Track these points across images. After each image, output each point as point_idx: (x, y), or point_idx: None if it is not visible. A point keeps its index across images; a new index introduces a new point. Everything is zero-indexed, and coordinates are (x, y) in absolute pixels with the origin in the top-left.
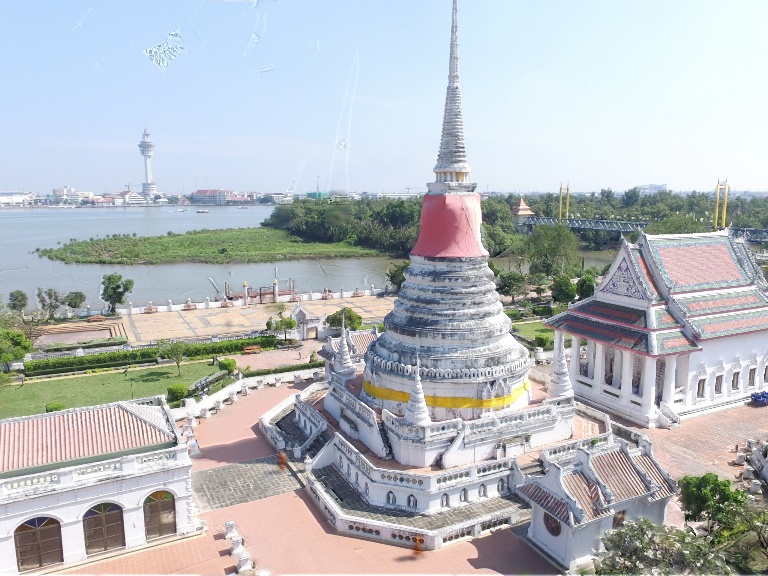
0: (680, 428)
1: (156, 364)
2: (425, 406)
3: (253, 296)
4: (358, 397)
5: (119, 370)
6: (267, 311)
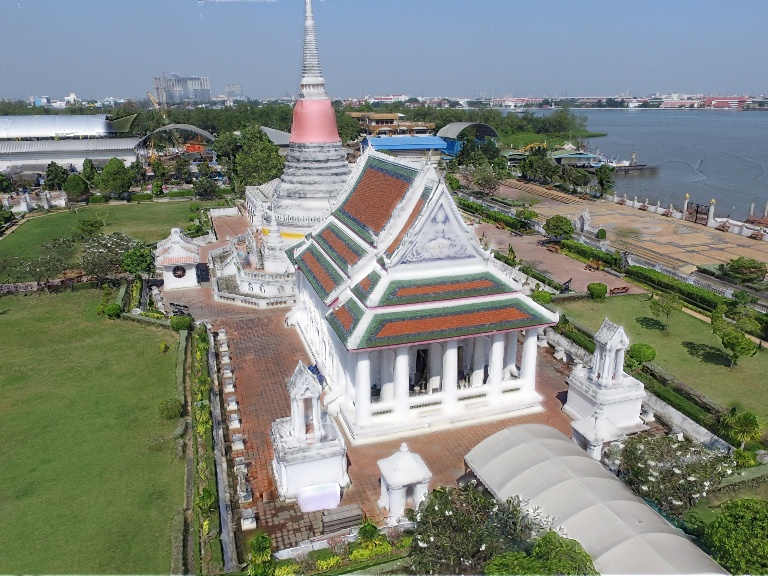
0: (282, 326)
1: (472, 215)
2: (258, 215)
3: (764, 223)
4: None
5: (462, 212)
6: (657, 225)
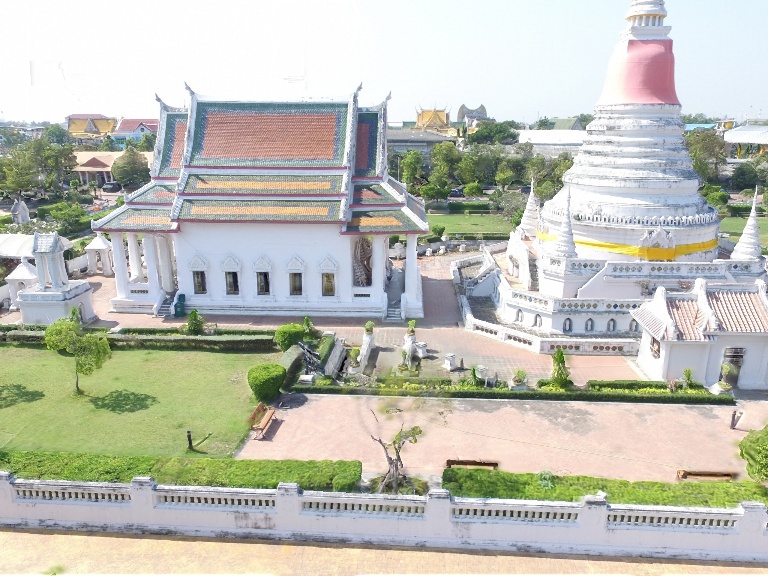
0: None
1: None
2: None
3: None
4: (723, 253)
5: None
6: None
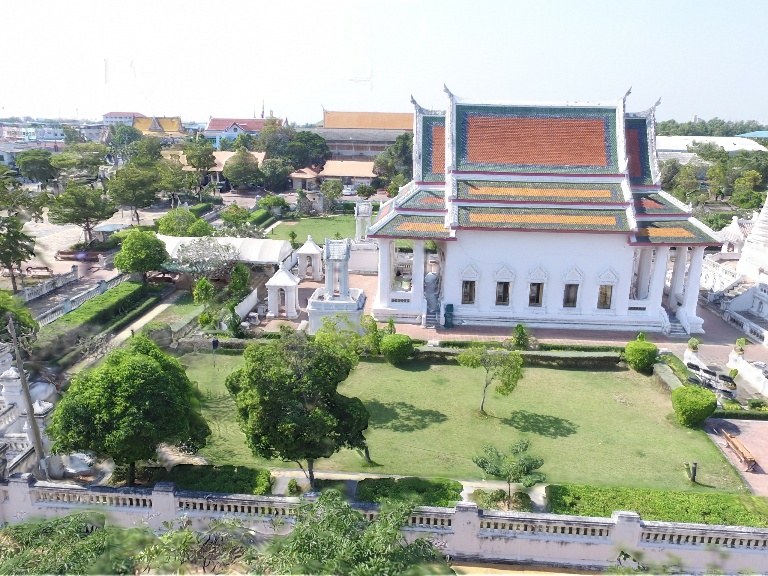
0: None
1: None
2: None
3: None
4: None
5: None
6: None
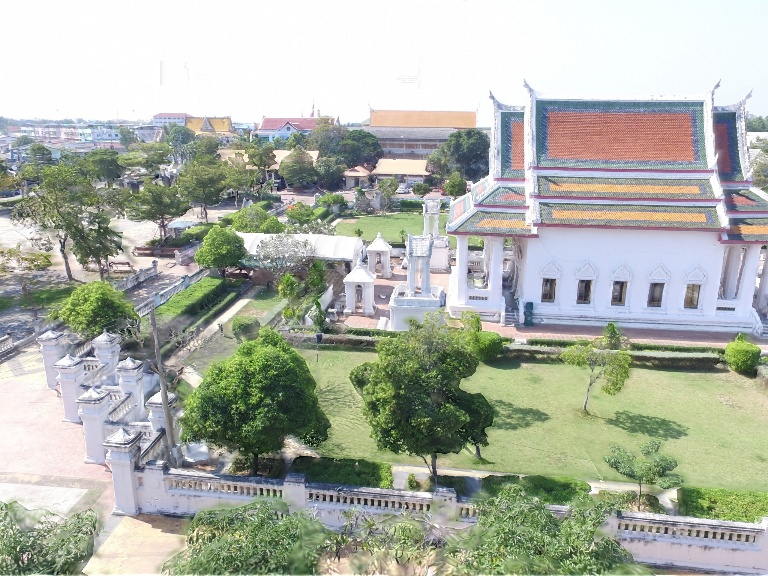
0: None
1: None
2: None
3: None
4: None
5: None
6: None
